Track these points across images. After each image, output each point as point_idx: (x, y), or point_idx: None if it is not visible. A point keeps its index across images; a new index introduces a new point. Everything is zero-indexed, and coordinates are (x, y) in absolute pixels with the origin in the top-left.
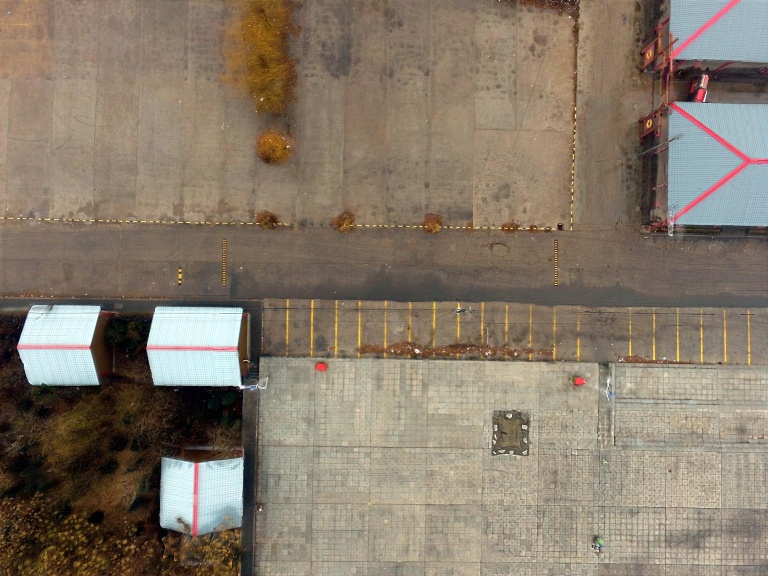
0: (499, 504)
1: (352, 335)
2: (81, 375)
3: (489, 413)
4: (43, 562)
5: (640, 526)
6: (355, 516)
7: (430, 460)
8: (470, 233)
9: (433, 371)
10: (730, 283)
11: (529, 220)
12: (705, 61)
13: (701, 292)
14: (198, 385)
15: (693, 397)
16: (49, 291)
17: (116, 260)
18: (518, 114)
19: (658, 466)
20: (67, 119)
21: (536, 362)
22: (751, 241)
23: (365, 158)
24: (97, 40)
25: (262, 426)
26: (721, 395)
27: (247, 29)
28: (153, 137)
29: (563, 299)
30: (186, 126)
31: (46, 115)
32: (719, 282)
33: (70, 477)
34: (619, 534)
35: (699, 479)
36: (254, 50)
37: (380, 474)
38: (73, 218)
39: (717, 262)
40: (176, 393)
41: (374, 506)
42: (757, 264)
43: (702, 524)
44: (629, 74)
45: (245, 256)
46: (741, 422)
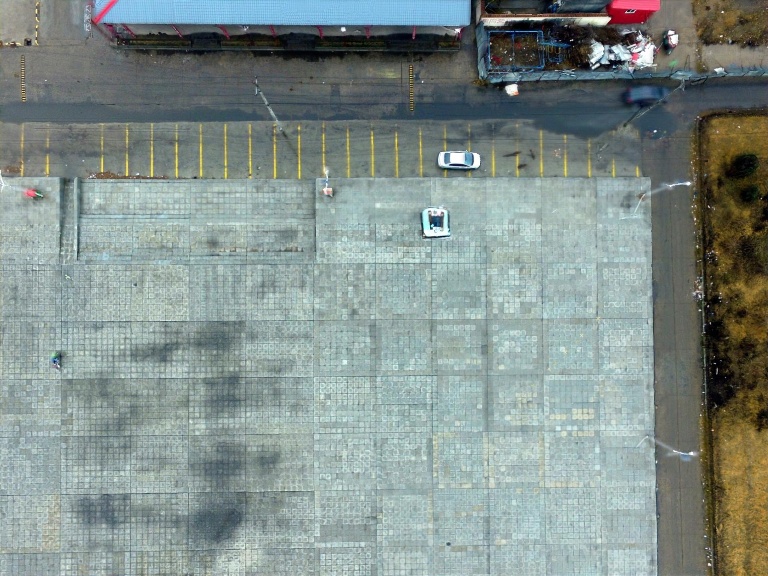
0: None
1: None
2: None
3: None
4: None
5: (105, 341)
6: None
7: None
8: None
9: None
10: (206, 97)
11: None
12: None
13: (176, 106)
14: None
15: (165, 212)
16: None
17: None
18: None
19: (123, 280)
20: None
21: None
22: (228, 54)
23: None
24: None
25: None
26: (194, 209)
27: None
28: None
29: (33, 116)
30: None
31: None
32: (195, 96)
33: None
34: (83, 349)
35: (166, 292)
36: None
37: None
38: None
39: (192, 75)
40: None
41: None
42: (233, 77)
43: (169, 337)
44: None
45: None
46: (213, 235)
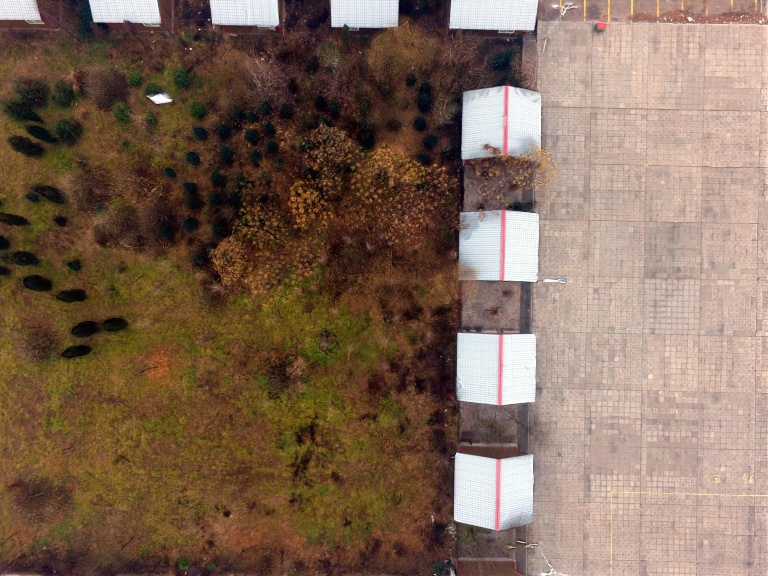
0: None
1: (625, 3)
2: (383, 15)
3: (767, 76)
4: (373, 165)
5: None
6: (632, 177)
7: (707, 123)
8: None
9: (710, 34)
10: None
11: None
12: None
13: None
14: (492, 29)
15: None
16: None
17: None
18: None
19: None
20: None
21: None
22: None
23: None
24: None
25: (540, 88)
26: None
27: None
28: None
29: None
30: None
31: None
32: None
33: (355, 137)
34: None
35: None
36: None
37: (657, 136)
38: None
39: None
40: None
41: (651, 167)
42: None
43: None
44: None
45: None
46: None
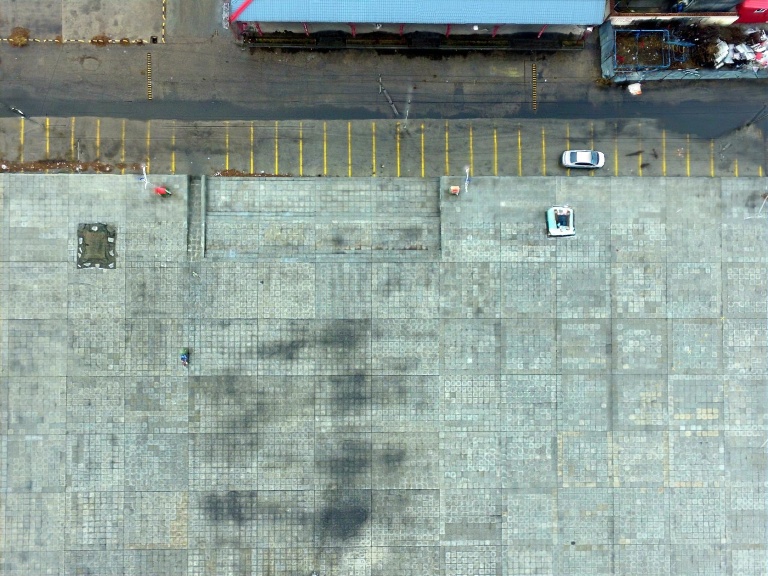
0: (86, 318)
1: None
2: None
3: (74, 226)
4: None
5: (231, 338)
6: None
7: (13, 274)
8: (59, 47)
9: (15, 184)
10: (330, 95)
11: (121, 33)
12: None
13: (300, 104)
14: None
15: (290, 209)
16: None
17: None
18: None
19: (250, 277)
20: None
21: (123, 174)
22: (352, 52)
23: None
24: None
25: None
26: (319, 207)
27: None
28: None
29: (158, 113)
30: None
31: None
32: (319, 94)
33: None
34: (210, 346)
35: (292, 290)
36: None
37: None
38: None
39: (316, 73)
40: None
41: None
42: (357, 75)
43: (295, 335)
44: None
45: None
46: (338, 233)
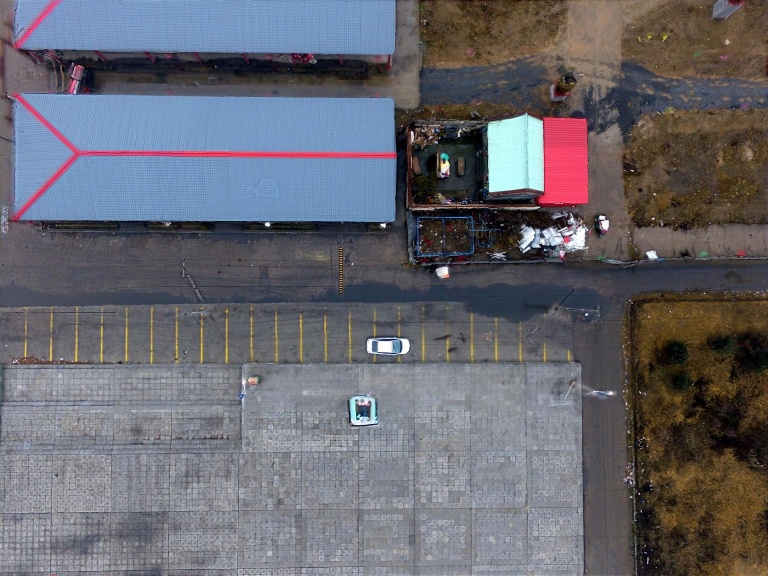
0: None
1: None
2: None
3: None
4: None
5: (24, 533)
6: None
7: None
8: None
9: None
10: (132, 280)
11: None
12: (60, 51)
13: (102, 290)
14: None
15: (89, 398)
16: None
17: None
18: None
19: (44, 470)
20: None
21: None
22: (155, 236)
23: None
24: None
25: None
26: (118, 395)
27: None
28: None
29: None
30: None
31: None
32: (121, 279)
33: None
34: (1, 542)
35: (87, 483)
36: None
37: None
38: None
39: (118, 258)
40: None
41: None
42: (160, 260)
43: (90, 529)
44: (24, 66)
45: None
46: (137, 423)
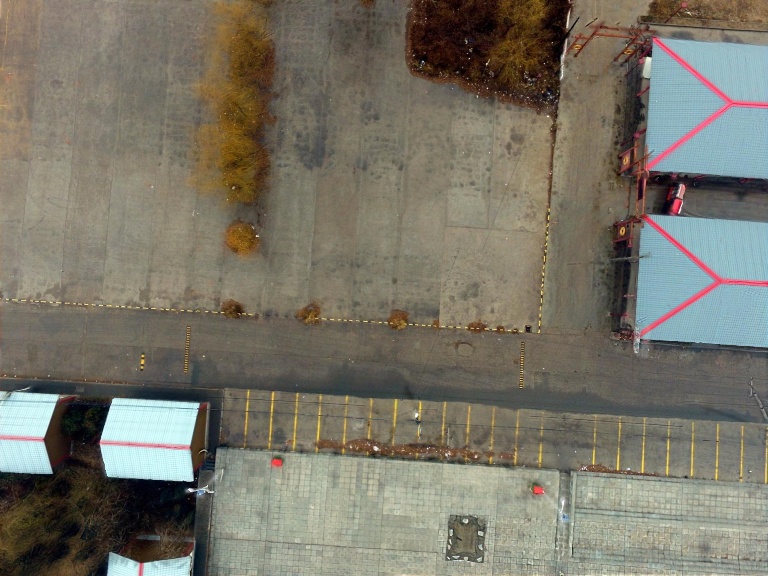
0: None
1: (311, 429)
2: (35, 464)
3: (445, 517)
4: None
5: None
6: None
7: (383, 562)
8: (436, 331)
9: (390, 471)
10: (700, 395)
11: (496, 321)
12: (681, 173)
13: (670, 403)
14: (151, 479)
15: (656, 511)
16: (13, 371)
17: (80, 343)
18: (491, 212)
19: None
20: (40, 200)
21: (496, 467)
22: (724, 353)
23: (334, 251)
24: (74, 123)
25: (215, 518)
26: (685, 510)
27: (223, 117)
28: (124, 221)
29: (527, 403)
30: (157, 212)
31: (20, 196)
32: (689, 393)
33: (22, 559)
34: None
35: None
36: (229, 138)
37: (331, 573)
38: (40, 299)
39: (688, 373)
40: (130, 483)
41: None
42: (729, 377)
43: None
44: (606, 177)
45: (208, 344)
46: (705, 540)
